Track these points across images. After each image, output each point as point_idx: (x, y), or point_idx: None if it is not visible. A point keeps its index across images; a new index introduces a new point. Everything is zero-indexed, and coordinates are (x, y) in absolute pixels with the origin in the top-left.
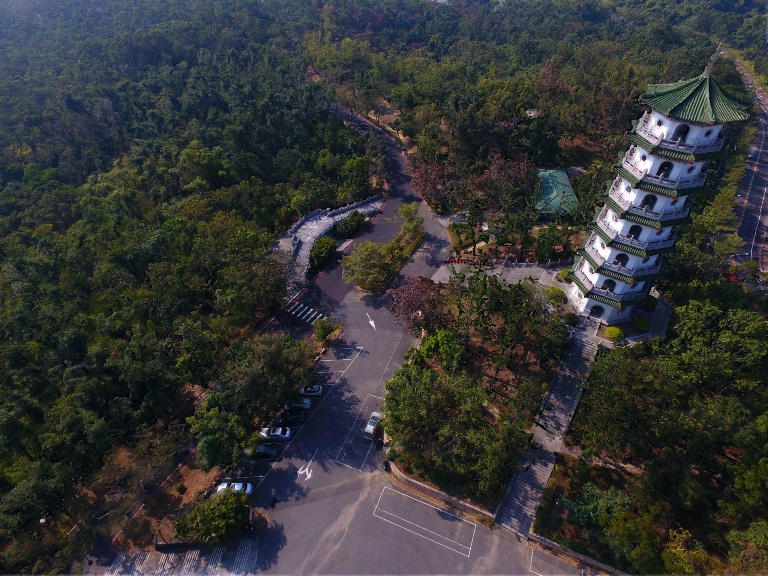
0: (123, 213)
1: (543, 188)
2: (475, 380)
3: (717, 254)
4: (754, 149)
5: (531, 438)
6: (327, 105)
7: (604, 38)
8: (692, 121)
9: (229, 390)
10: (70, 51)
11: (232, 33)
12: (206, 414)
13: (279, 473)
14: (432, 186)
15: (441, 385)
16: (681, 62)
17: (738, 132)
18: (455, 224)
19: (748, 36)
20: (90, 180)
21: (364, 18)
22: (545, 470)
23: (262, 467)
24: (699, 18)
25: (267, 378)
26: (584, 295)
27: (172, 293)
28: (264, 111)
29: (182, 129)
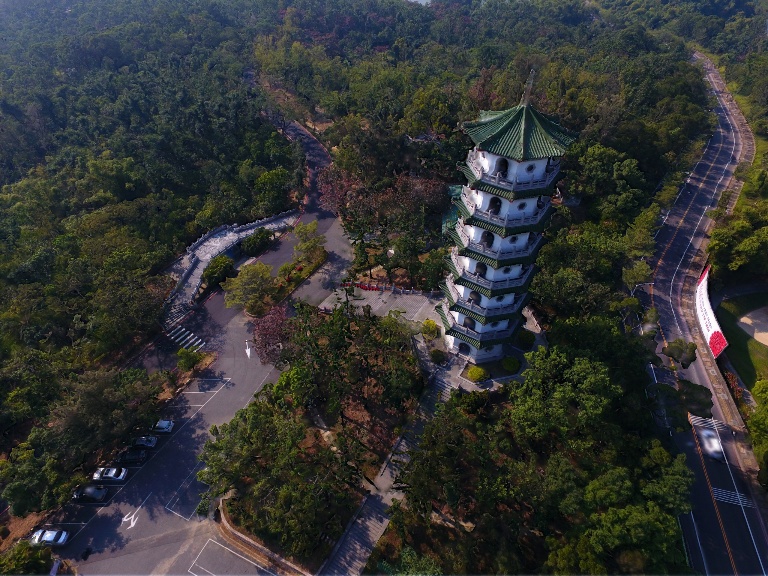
0: (35, 224)
1: (455, 207)
2: (330, 420)
3: (625, 282)
4: (706, 163)
5: (343, 498)
6: (259, 113)
7: (576, 42)
8: None
9: (55, 429)
10: (22, 53)
11: (181, 36)
12: (19, 457)
13: (103, 520)
14: (342, 202)
15: (274, 430)
16: (635, 70)
17: (684, 146)
18: None
19: (728, 41)
20: (4, 190)
21: (332, 20)
22: (379, 526)
23: (87, 512)
24: (680, 22)
25: (88, 419)
26: (445, 332)
27: (42, 316)
28: (193, 119)
29: (106, 137)
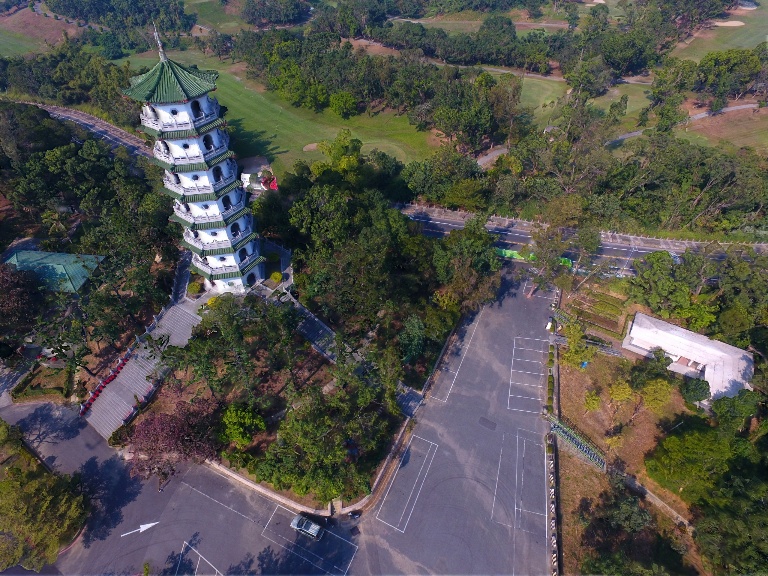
0: None
1: None
2: (281, 404)
3: None
4: None
5: None
6: None
7: None
8: None
9: None
10: None
11: None
12: None
13: None
14: None
15: None
16: None
17: None
18: (16, 389)
19: None
20: None
21: None
22: None
23: None
24: None
25: None
26: (242, 276)
27: None
28: None
29: None
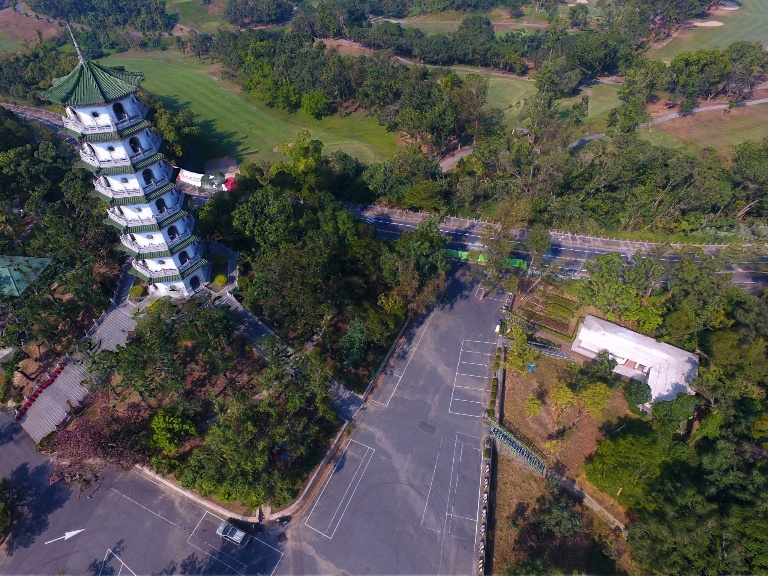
0: None
1: None
2: None
3: None
4: None
5: None
6: None
7: None
8: (122, 96)
9: None
10: None
11: None
12: None
13: None
14: None
15: None
16: None
17: None
18: None
19: None
20: None
21: None
22: None
23: None
24: None
25: None
26: (181, 279)
27: None
28: None
29: None
